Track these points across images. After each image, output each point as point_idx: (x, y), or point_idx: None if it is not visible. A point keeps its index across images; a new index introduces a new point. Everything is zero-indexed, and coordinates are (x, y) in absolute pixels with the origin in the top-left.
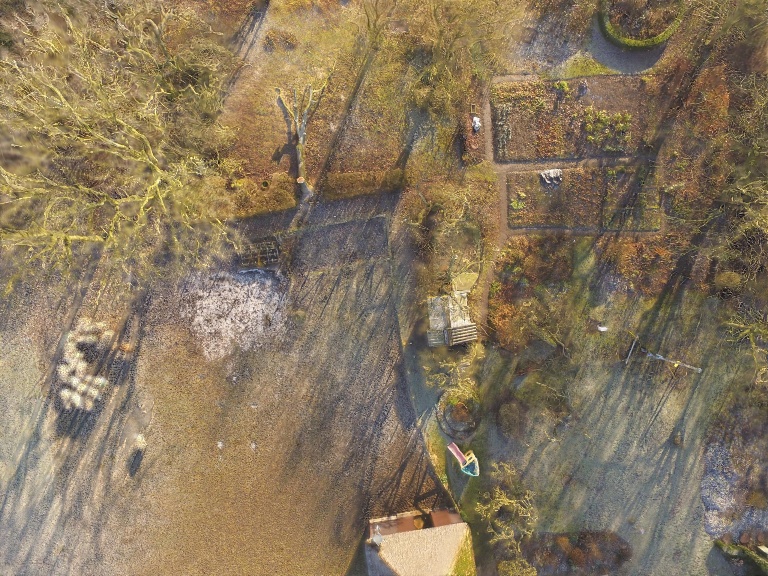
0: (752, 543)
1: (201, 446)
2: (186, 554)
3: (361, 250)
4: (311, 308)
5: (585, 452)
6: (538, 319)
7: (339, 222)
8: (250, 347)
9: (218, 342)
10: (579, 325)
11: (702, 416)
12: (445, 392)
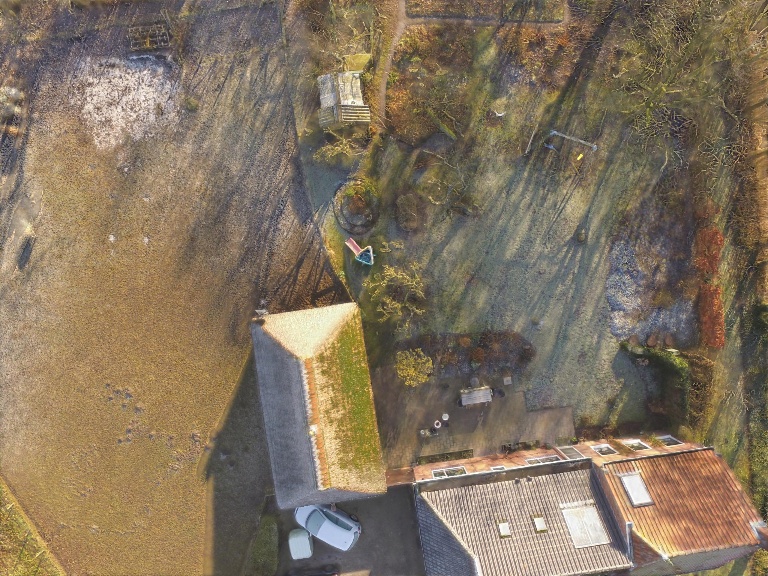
0: (659, 346)
1: (92, 239)
2: (77, 351)
3: (255, 37)
4: (204, 97)
5: (487, 250)
6: (437, 111)
7: (232, 7)
8: (142, 136)
9: (109, 131)
10: (479, 117)
11: (607, 214)
12: (342, 185)
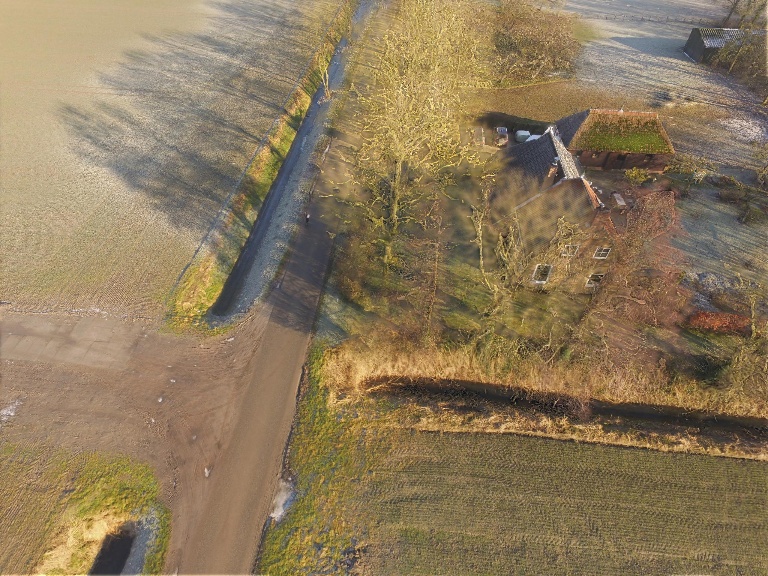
0: None
1: None
2: None
3: None
4: None
5: None
6: None
7: None
8: None
9: None
10: None
11: None
12: None
